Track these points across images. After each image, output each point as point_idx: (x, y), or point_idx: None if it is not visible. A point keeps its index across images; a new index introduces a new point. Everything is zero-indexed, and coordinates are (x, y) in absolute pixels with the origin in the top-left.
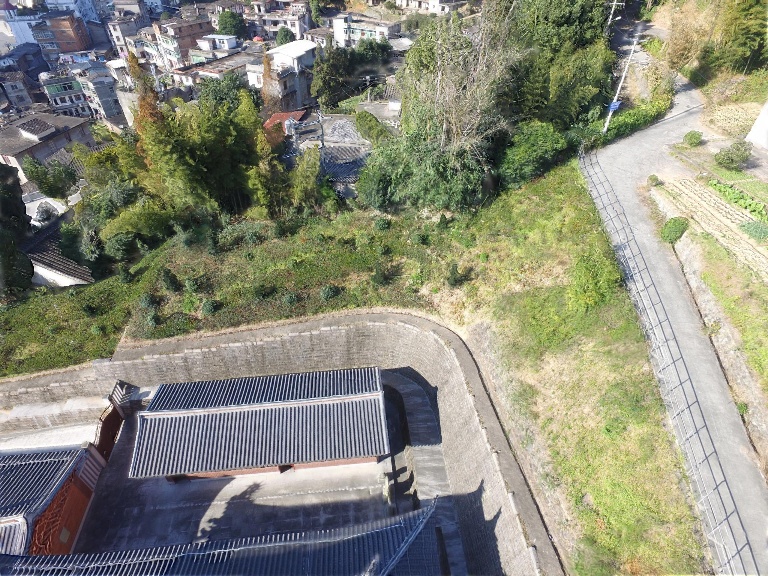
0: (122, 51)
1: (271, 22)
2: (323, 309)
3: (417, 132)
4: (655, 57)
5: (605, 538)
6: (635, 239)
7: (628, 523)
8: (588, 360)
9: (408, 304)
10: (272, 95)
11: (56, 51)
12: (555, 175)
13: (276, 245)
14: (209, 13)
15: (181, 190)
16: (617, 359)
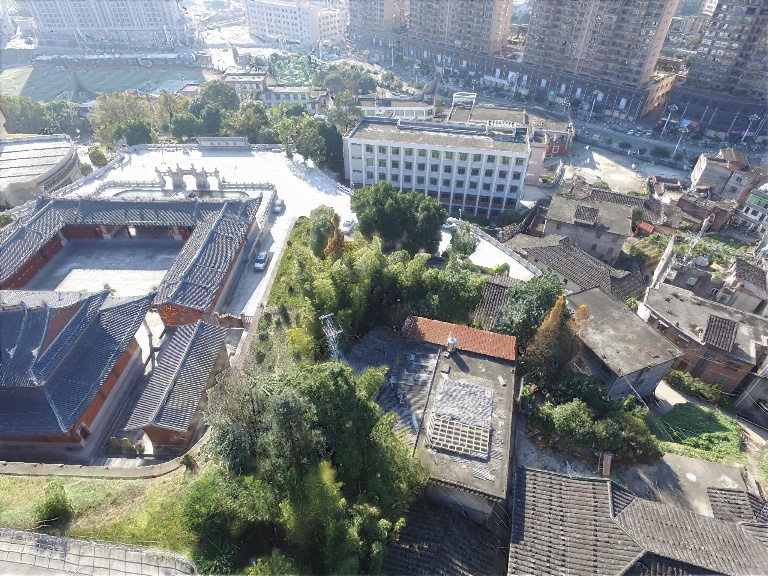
0: None
1: None
2: None
3: None
4: None
5: None
6: (62, 570)
7: None
8: None
9: None
10: (551, 329)
11: None
12: None
13: None
14: None
15: None
16: None
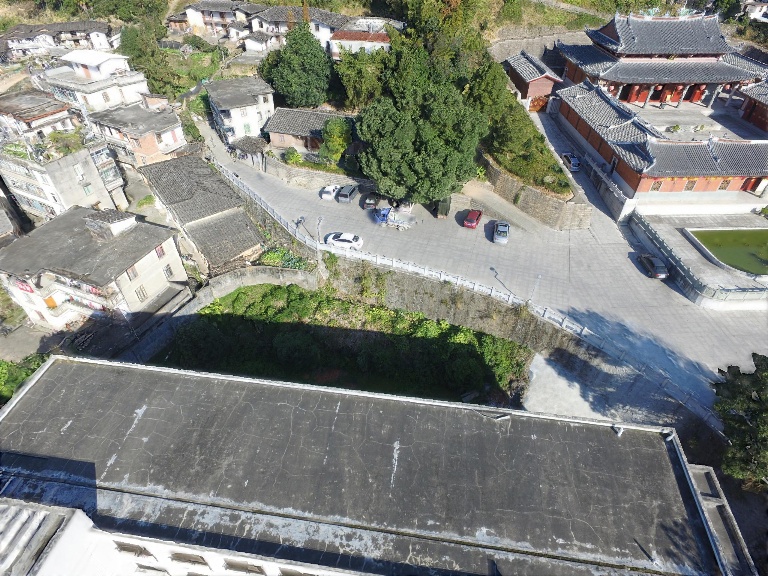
0: None
1: None
2: None
3: None
4: None
5: None
6: None
7: (564, 17)
8: (526, 11)
9: None
10: None
11: None
12: None
13: None
14: None
15: None
16: (529, 6)
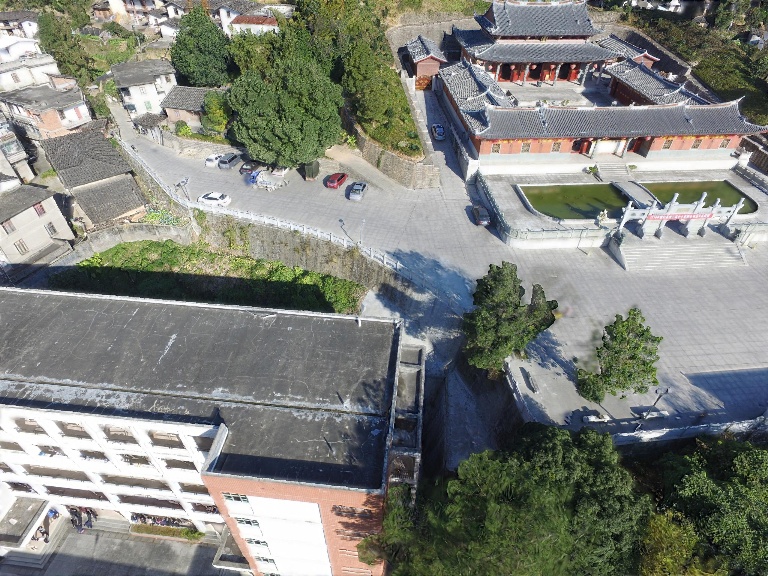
0: None
1: None
2: None
3: None
4: None
5: (463, 8)
6: None
7: (461, 4)
8: None
9: None
10: None
11: None
12: None
13: None
14: None
15: None
16: None
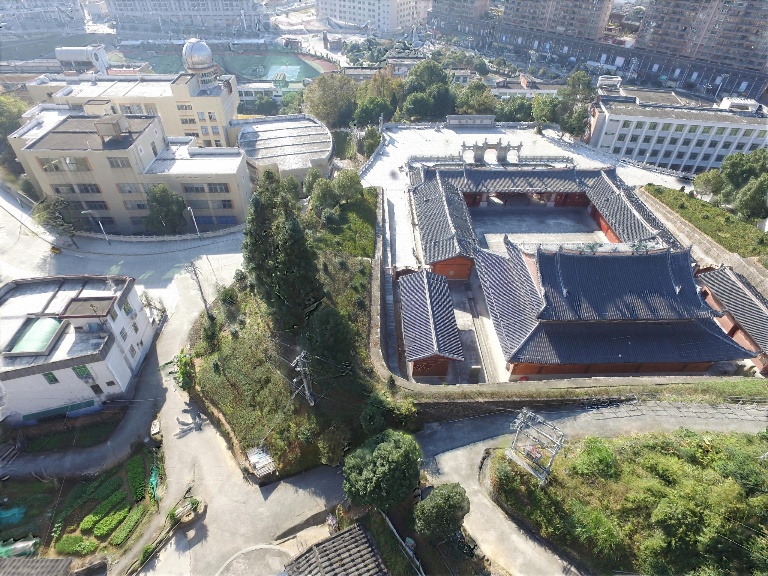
0: None
1: None
2: None
3: None
4: None
5: None
6: None
7: None
8: None
9: None
10: None
11: None
12: None
13: None
14: None
15: None
16: None
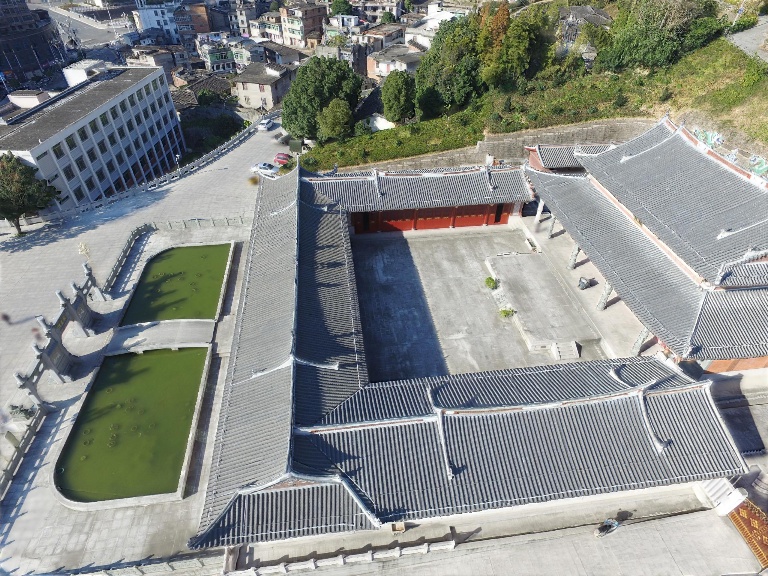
0: (244, 32)
1: (371, 8)
2: (589, 119)
3: (646, 22)
4: (732, 4)
5: None
6: None
7: None
8: (756, 103)
9: (636, 114)
10: None
11: (190, 32)
12: (714, 44)
13: (554, 91)
14: (317, 1)
15: (517, 55)
16: None
